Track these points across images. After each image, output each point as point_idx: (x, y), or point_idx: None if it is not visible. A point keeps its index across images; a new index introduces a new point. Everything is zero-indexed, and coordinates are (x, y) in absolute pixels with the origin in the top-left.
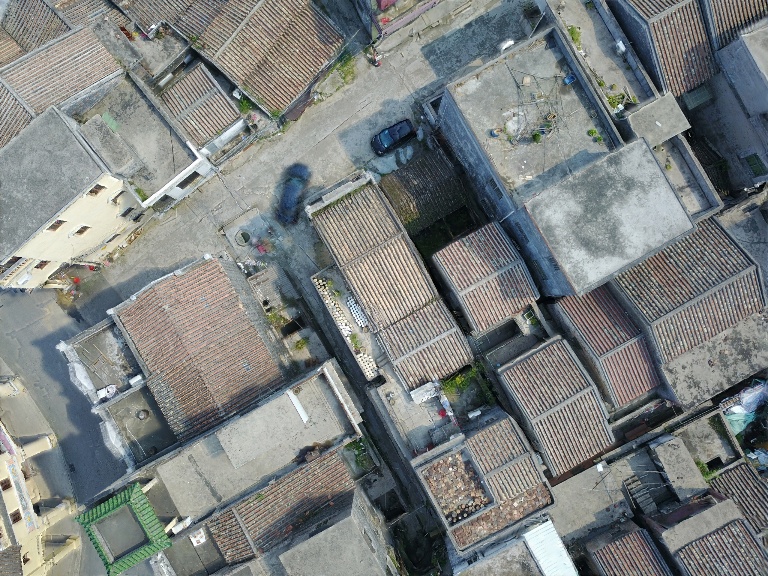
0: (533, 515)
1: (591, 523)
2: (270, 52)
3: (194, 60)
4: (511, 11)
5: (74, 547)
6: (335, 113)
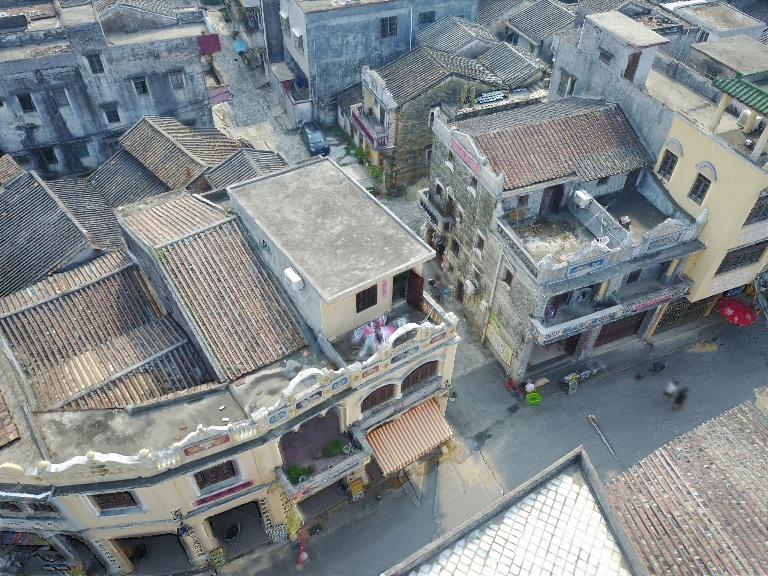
0: None
1: None
2: None
3: None
4: (229, 86)
5: None
6: None
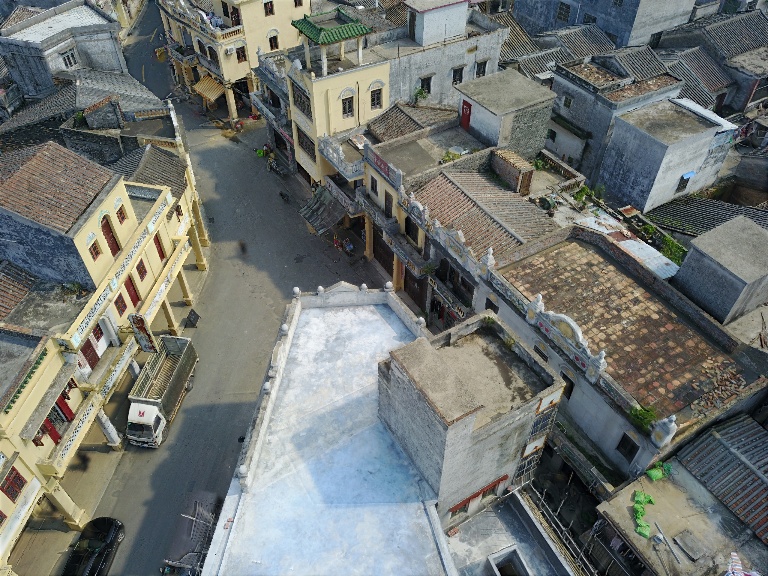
0: (668, 86)
1: (729, 174)
2: (398, 8)
3: None
4: None
5: (204, 261)
6: None
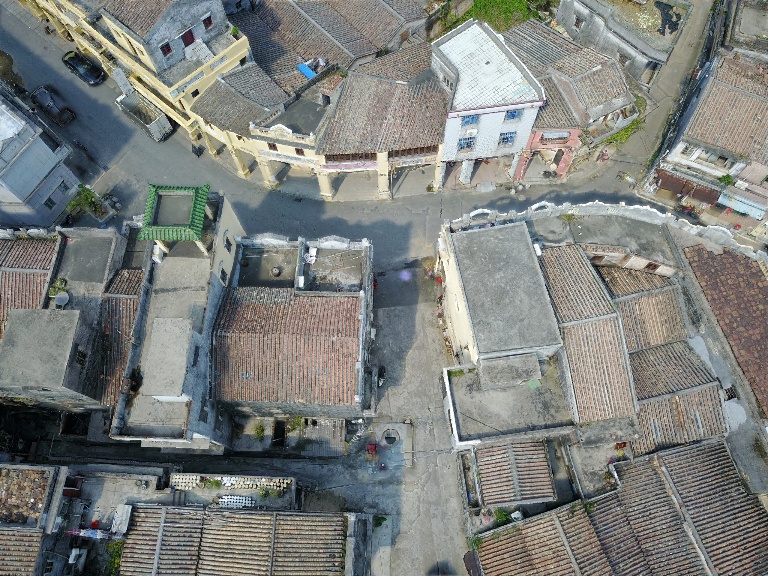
0: None
1: None
2: None
3: (573, 494)
4: None
5: (240, 171)
6: None
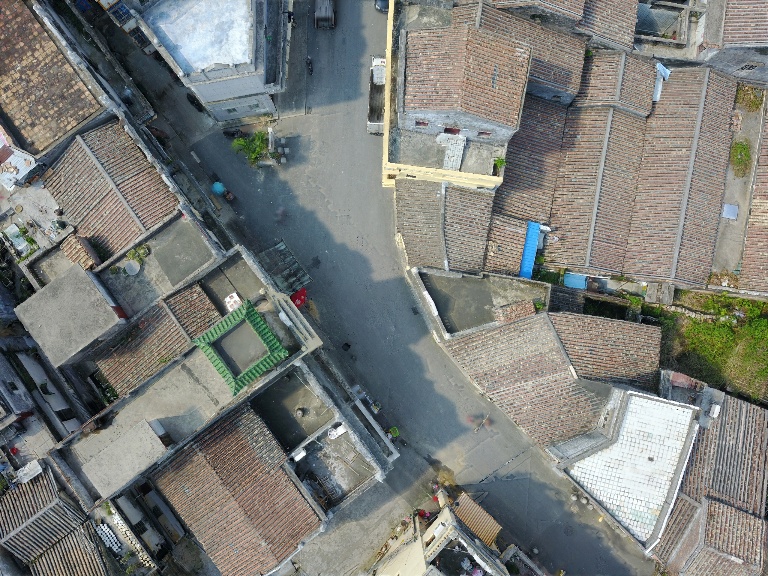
0: None
1: None
2: None
3: None
4: None
5: None
6: None
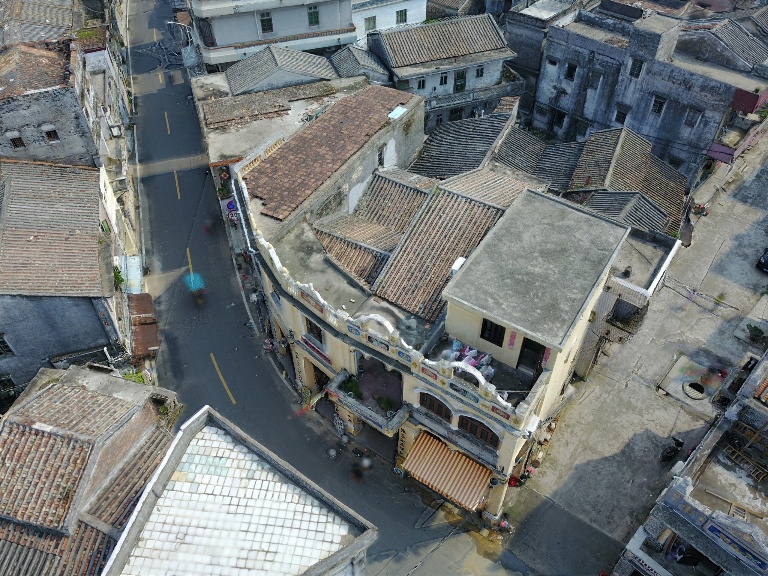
0: None
1: None
2: None
3: None
4: None
5: None
6: (698, 255)
